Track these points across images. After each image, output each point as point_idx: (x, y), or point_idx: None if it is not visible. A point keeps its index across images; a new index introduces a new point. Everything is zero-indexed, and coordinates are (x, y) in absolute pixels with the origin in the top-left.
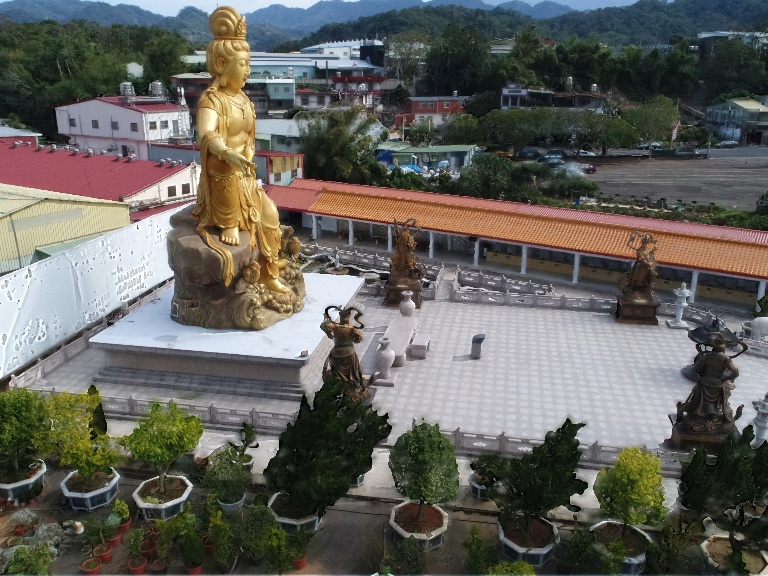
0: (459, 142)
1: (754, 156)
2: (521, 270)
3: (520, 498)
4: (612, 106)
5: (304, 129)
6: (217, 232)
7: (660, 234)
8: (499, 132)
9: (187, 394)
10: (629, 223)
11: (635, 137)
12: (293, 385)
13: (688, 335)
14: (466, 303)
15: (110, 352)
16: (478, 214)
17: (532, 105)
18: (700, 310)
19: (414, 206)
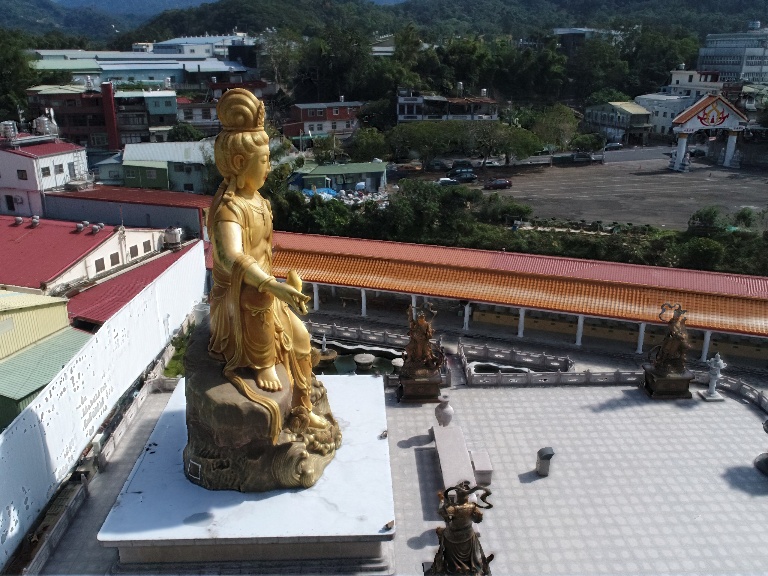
0: (367, 158)
1: (643, 159)
2: (518, 333)
3: None
4: (513, 115)
5: (210, 157)
6: (250, 374)
7: (665, 291)
8: (409, 147)
9: None
10: (617, 272)
11: (540, 147)
12: (373, 560)
13: (765, 430)
14: (486, 388)
15: (125, 547)
16: (464, 273)
17: (429, 113)
18: (728, 377)
19: (389, 265)
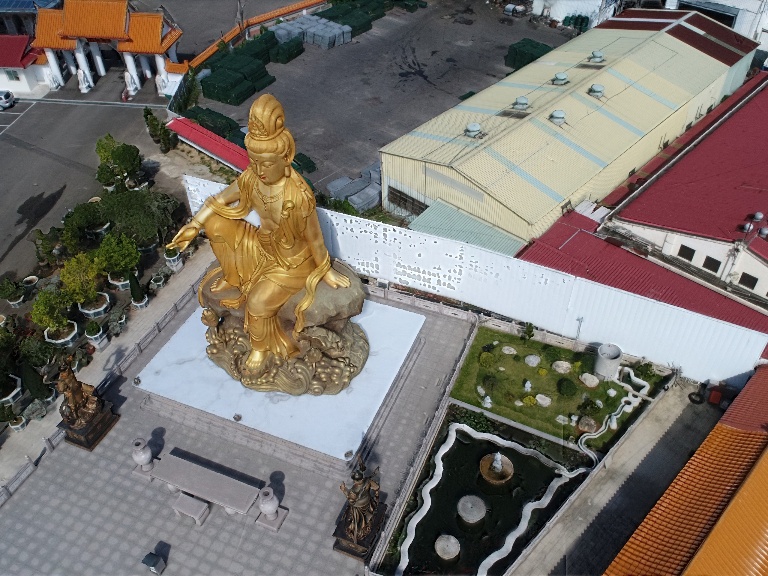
0: None
1: None
2: None
3: None
4: None
5: None
6: None
7: None
8: None
9: None
10: None
11: None
12: None
13: None
14: None
15: None
16: None
17: None
18: None
19: (667, 573)
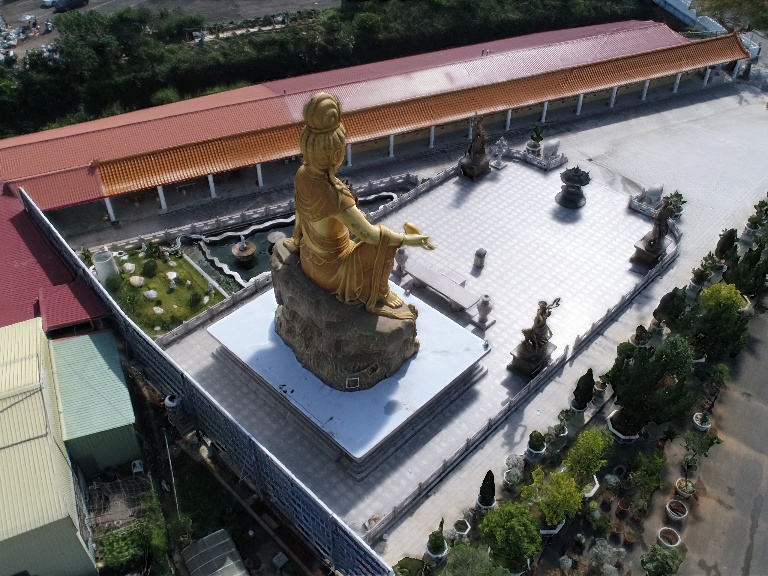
0: None
1: None
2: (349, 164)
3: (700, 339)
4: None
5: None
6: (379, 303)
7: (439, 96)
8: None
9: (430, 430)
10: (383, 86)
11: None
12: (477, 368)
13: (566, 183)
14: (381, 221)
15: None
16: (293, 130)
17: None
18: None
19: (224, 144)
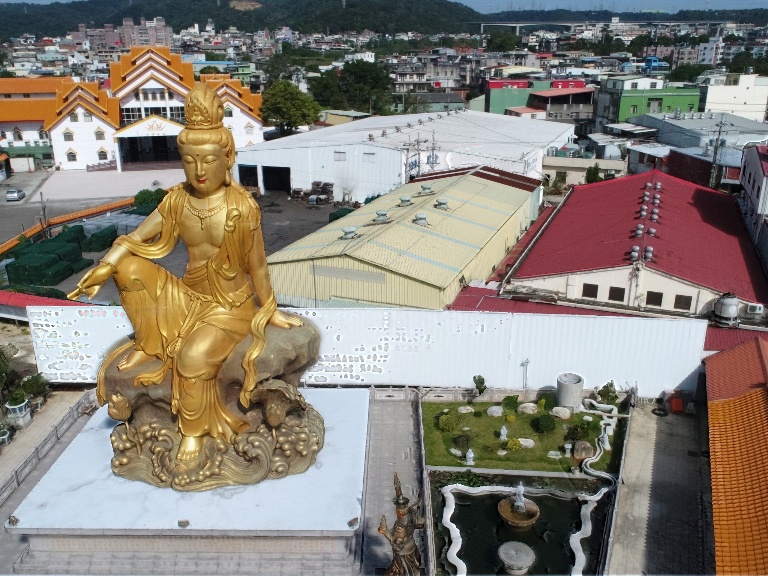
0: None
1: None
2: None
3: None
4: None
5: None
6: None
7: None
8: None
9: None
10: None
11: None
12: None
13: None
14: None
15: None
16: None
17: None
18: None
19: None
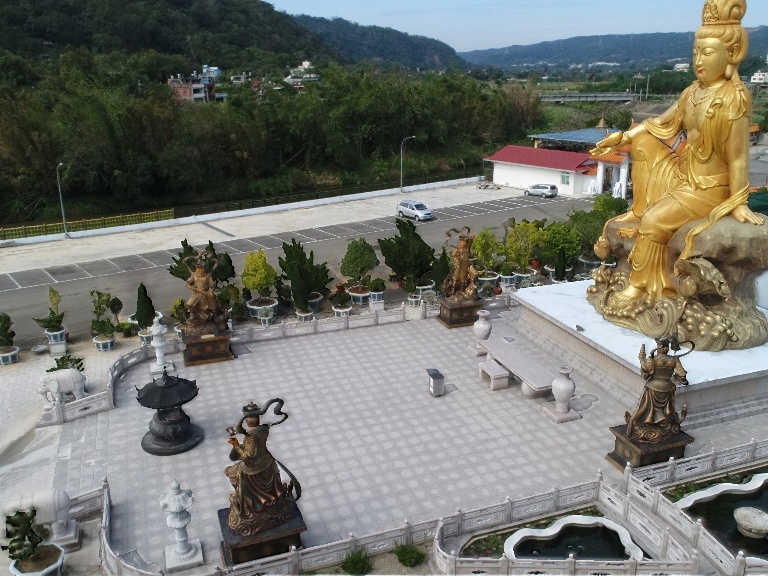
0: None
1: None
2: None
3: None
4: None
5: None
6: None
7: None
8: None
9: None
10: None
11: None
12: None
13: None
14: None
15: None
16: None
17: None
18: None
19: None
